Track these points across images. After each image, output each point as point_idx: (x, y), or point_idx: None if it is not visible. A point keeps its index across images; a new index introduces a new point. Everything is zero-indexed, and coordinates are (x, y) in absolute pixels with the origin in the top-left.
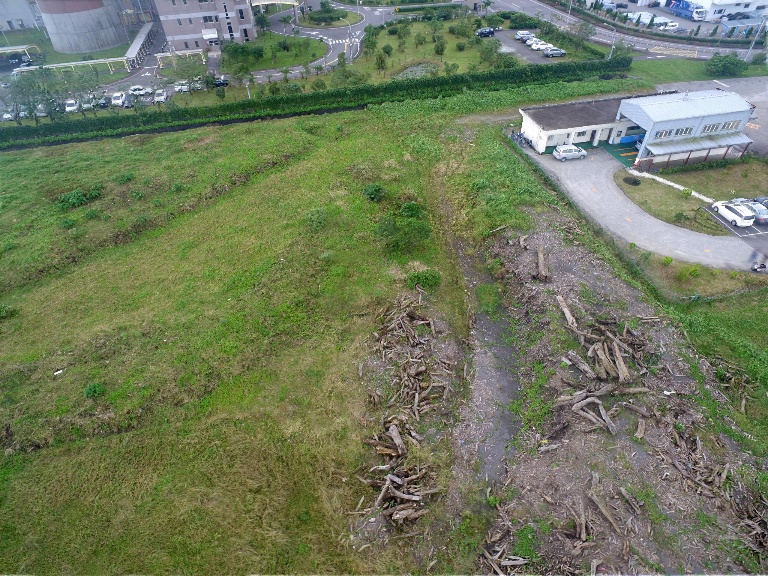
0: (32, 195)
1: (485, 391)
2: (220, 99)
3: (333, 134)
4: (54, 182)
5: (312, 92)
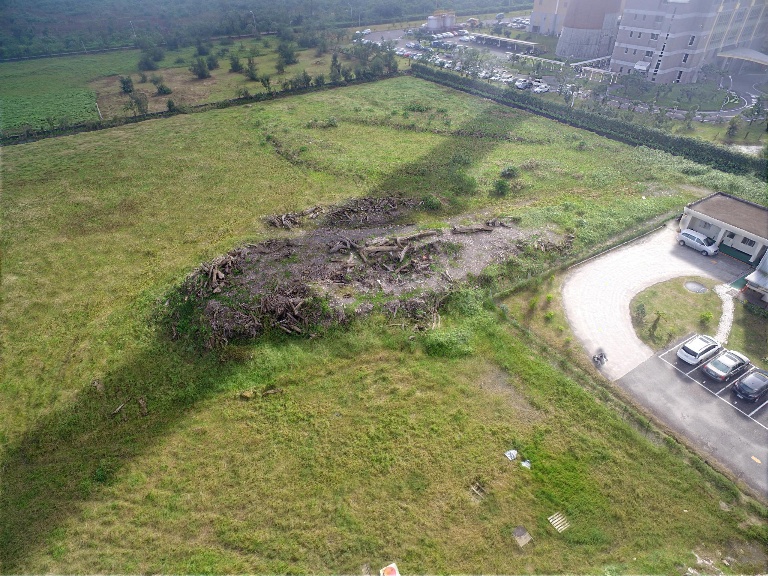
0: (409, 100)
1: (355, 233)
2: (566, 103)
3: (573, 145)
4: (423, 99)
5: (613, 118)
